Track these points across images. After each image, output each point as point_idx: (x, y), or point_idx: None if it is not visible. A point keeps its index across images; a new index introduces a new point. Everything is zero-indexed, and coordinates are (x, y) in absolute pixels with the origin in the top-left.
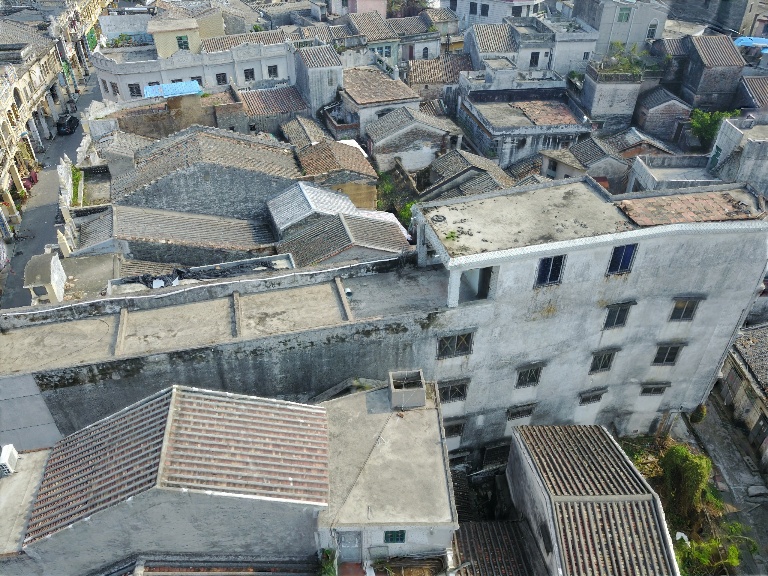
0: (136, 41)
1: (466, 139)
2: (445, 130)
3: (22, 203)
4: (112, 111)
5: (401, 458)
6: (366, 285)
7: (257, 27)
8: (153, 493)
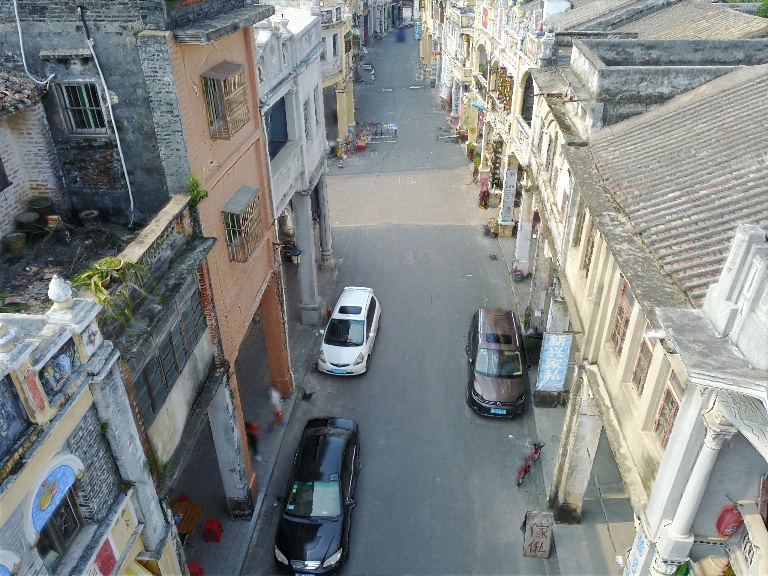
0: None
1: None
2: None
3: None
4: None
5: None
6: None
7: None
8: None
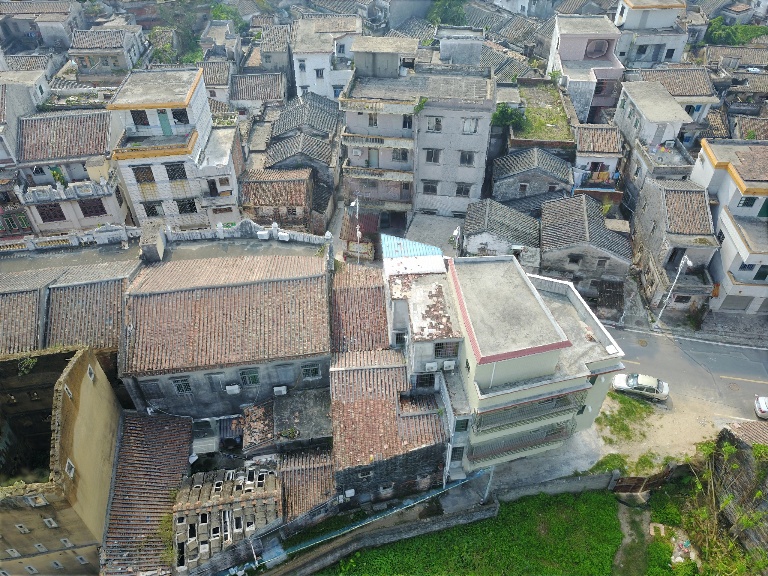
0: None
1: None
2: None
3: None
4: None
5: None
6: None
7: None
8: (7, 86)
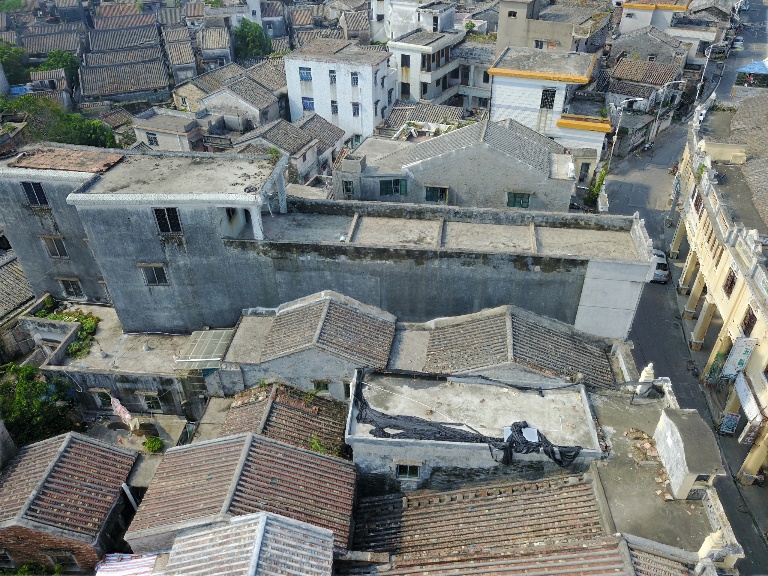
0: None
1: None
2: None
3: None
4: None
5: (375, 153)
6: None
7: None
8: None
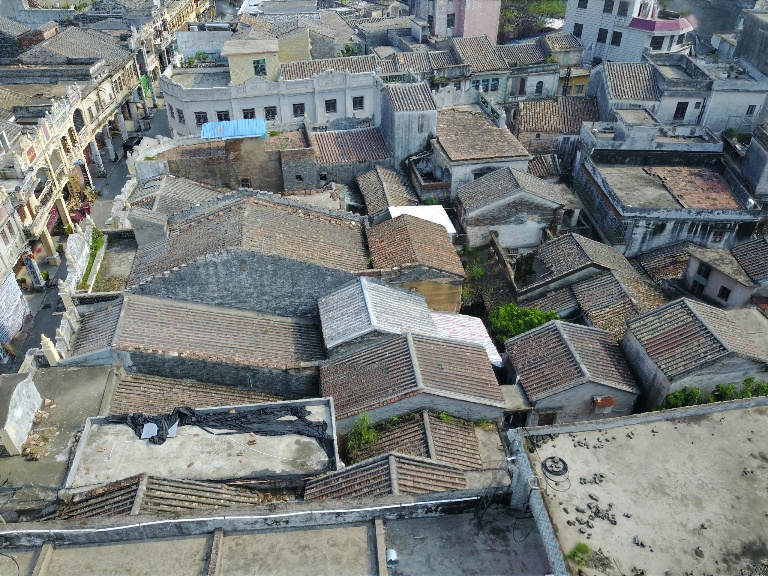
0: (212, 61)
1: (583, 209)
2: (558, 203)
3: (66, 240)
4: (166, 148)
5: None
6: (423, 539)
7: (349, 47)
8: None
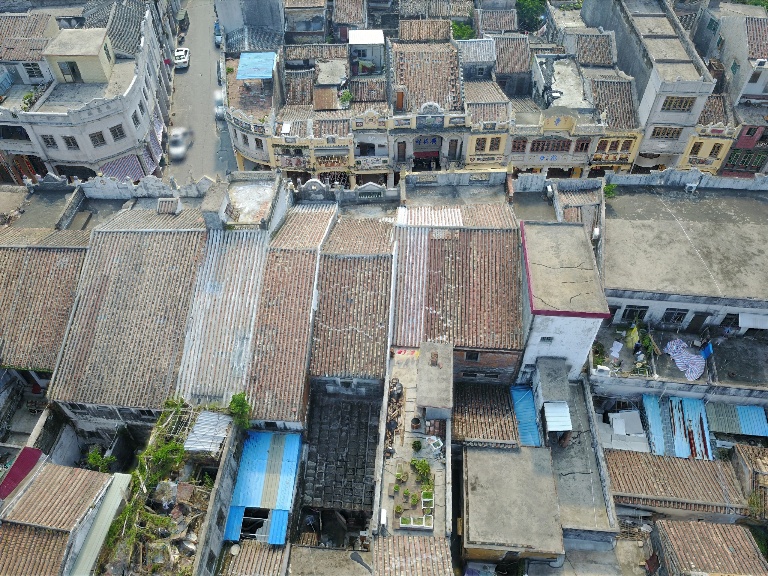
0: None
1: None
2: None
3: None
4: None
5: None
6: None
7: None
8: None
